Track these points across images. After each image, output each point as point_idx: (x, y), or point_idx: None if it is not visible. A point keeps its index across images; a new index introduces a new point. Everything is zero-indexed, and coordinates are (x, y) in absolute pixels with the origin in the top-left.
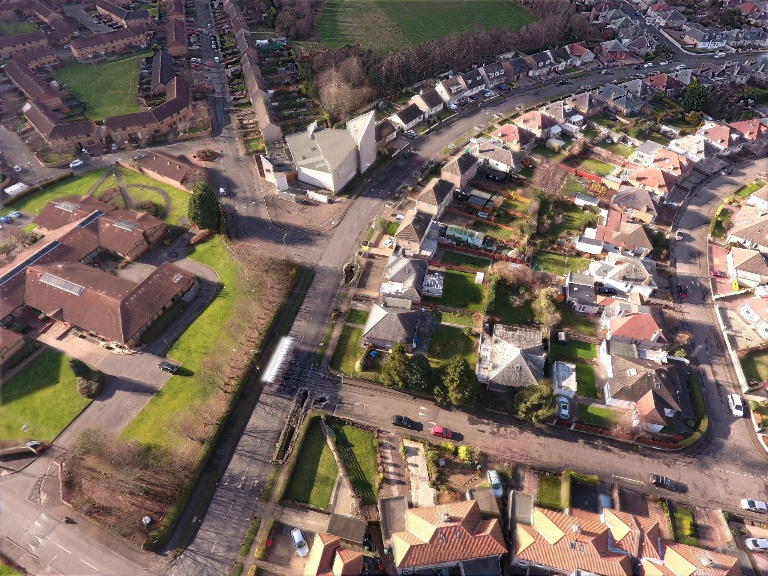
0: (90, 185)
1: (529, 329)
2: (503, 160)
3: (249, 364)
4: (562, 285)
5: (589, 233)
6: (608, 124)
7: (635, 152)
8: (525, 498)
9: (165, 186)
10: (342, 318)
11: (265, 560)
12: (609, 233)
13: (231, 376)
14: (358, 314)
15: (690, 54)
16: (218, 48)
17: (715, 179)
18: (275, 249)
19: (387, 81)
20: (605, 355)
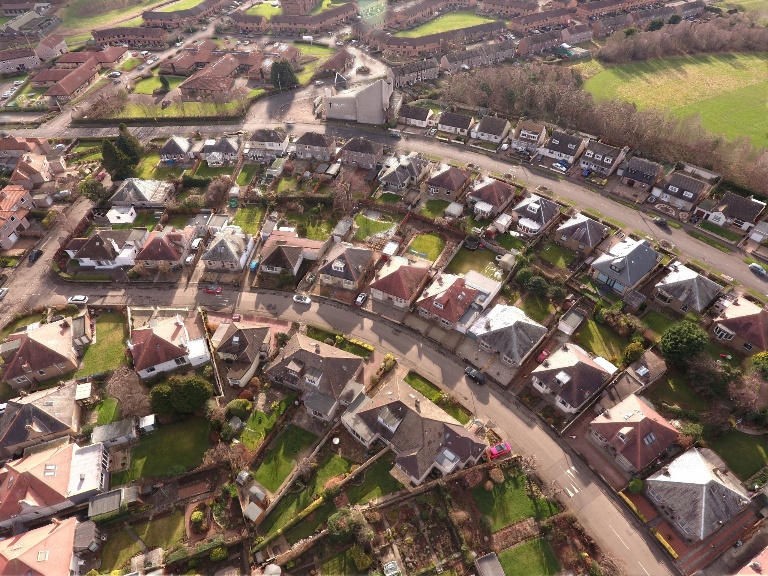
0: (318, 52)
1: None
2: None
3: (160, 117)
4: None
5: (286, 229)
6: (529, 249)
7: None
8: (43, 197)
9: None
10: None
11: (55, 143)
12: (284, 238)
13: None
14: None
15: None
16: None
17: (450, 359)
18: (260, 109)
19: None
20: None
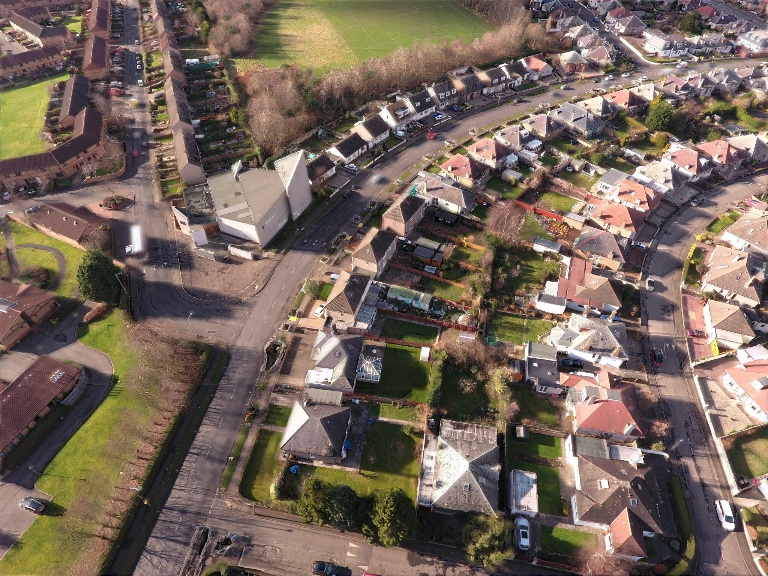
0: None
1: (482, 421)
2: (453, 200)
3: (136, 496)
4: (521, 357)
5: (550, 288)
6: (568, 150)
7: (598, 181)
8: None
9: (62, 245)
10: (259, 419)
11: None
12: (572, 288)
13: (113, 513)
14: (279, 412)
15: (652, 64)
16: (143, 69)
17: (685, 211)
18: (185, 325)
19: (329, 104)
20: (571, 456)
